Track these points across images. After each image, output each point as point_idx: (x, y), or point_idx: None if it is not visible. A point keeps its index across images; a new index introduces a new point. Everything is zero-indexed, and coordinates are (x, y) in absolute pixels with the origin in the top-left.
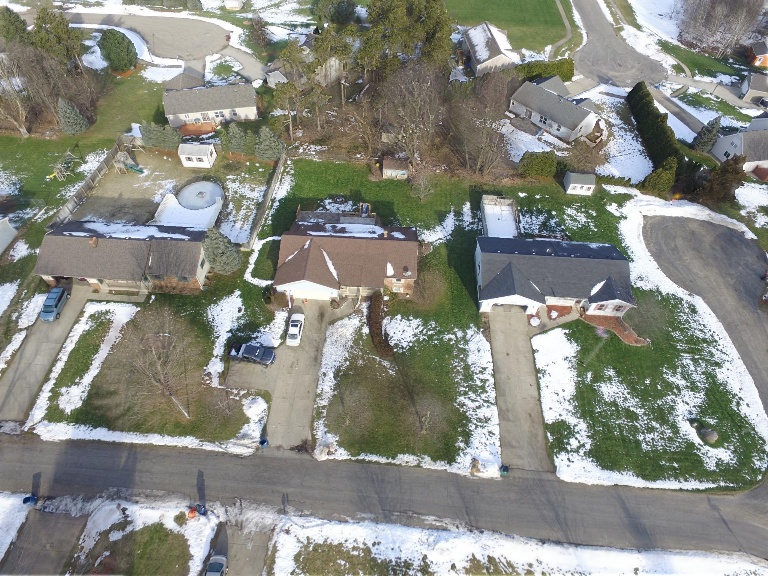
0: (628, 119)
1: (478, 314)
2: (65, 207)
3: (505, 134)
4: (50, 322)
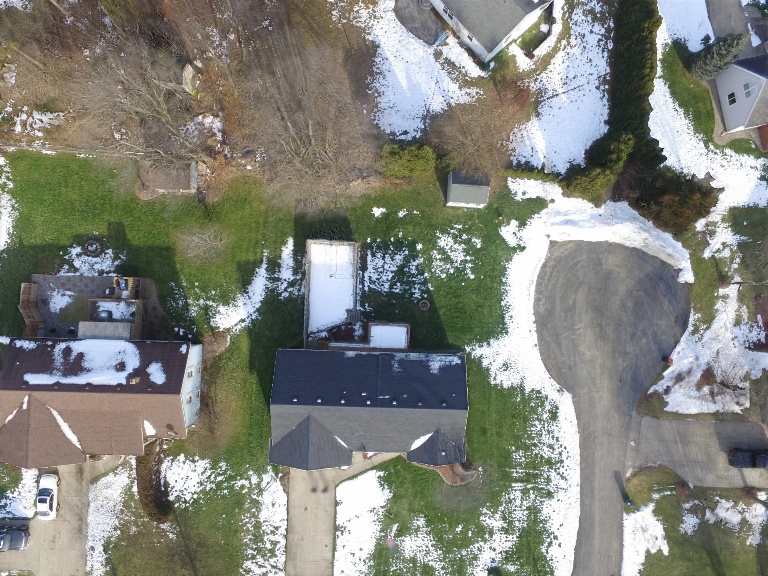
0: None
1: None
2: None
3: (379, 45)
4: None
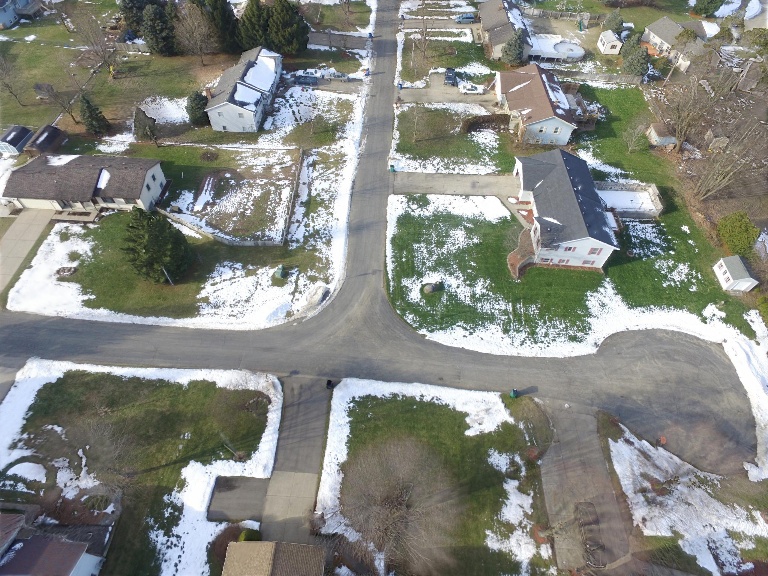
0: None
1: (511, 172)
2: (533, 9)
3: None
4: (455, 22)
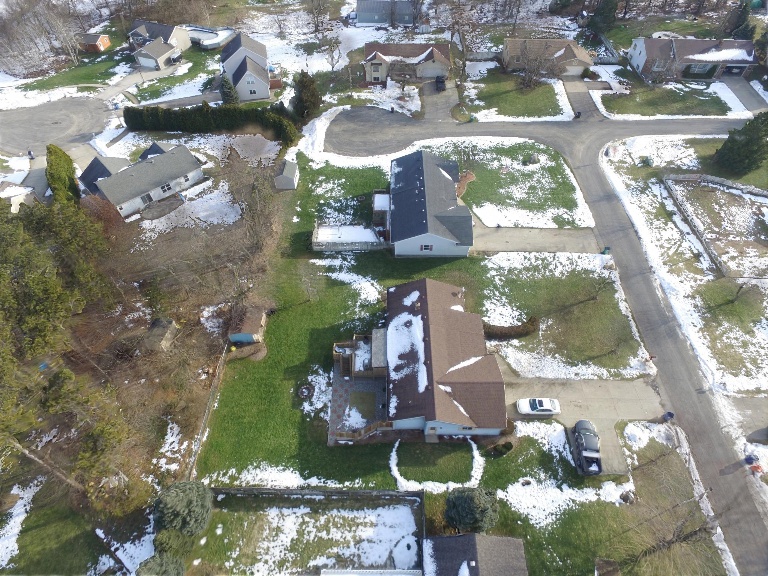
0: (171, 135)
1: (470, 258)
2: None
3: (175, 226)
4: None
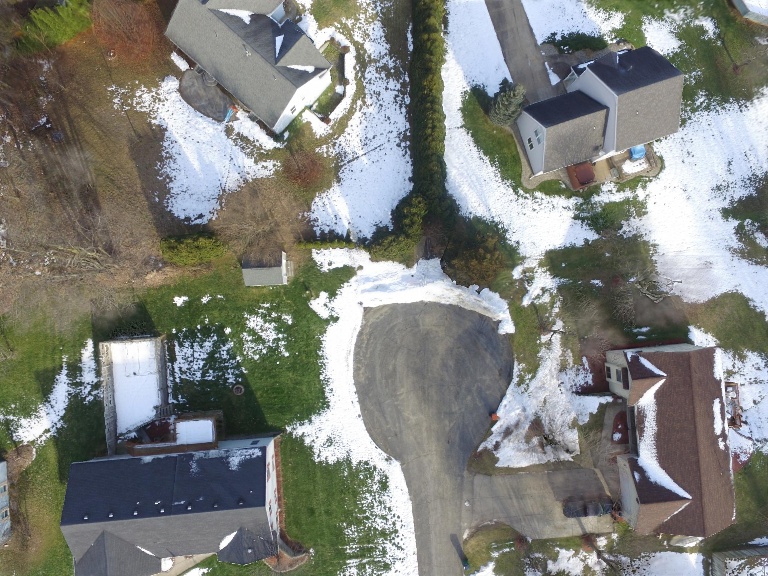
0: None
1: None
2: None
3: (167, 128)
4: None
